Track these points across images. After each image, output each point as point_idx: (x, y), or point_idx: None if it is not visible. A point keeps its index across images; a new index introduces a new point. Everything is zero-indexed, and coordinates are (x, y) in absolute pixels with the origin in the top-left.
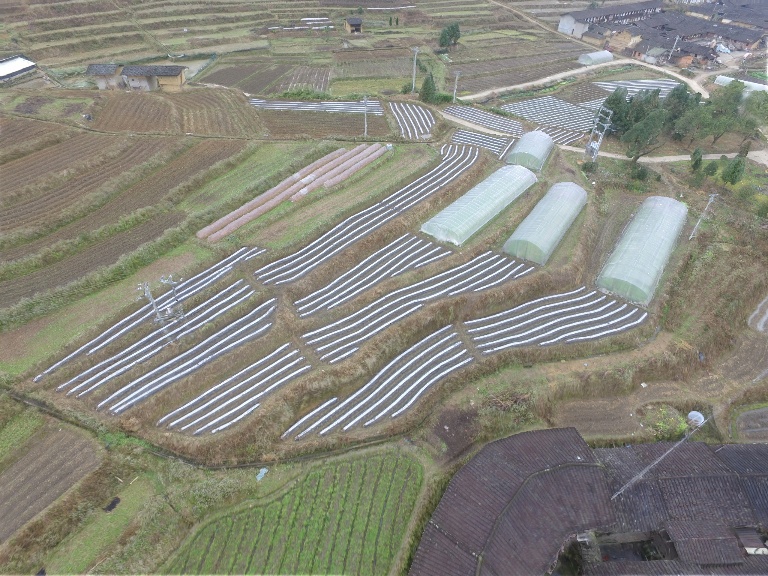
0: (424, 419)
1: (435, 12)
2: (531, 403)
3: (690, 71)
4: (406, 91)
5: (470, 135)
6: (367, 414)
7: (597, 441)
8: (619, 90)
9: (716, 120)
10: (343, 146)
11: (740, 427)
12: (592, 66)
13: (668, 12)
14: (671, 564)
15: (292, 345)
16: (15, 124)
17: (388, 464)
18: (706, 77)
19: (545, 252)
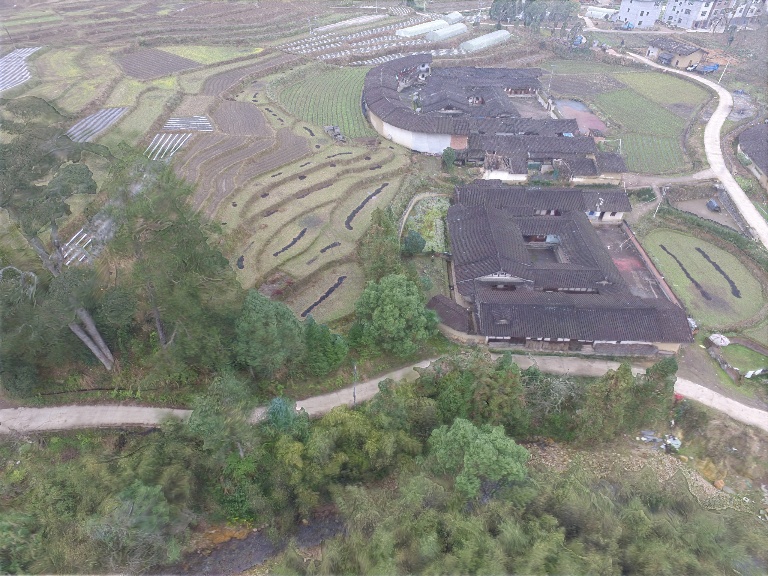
0: None
1: None
2: None
3: None
4: None
5: None
6: None
7: None
8: None
9: (540, 6)
10: None
11: None
12: None
13: None
14: None
15: None
16: (231, 5)
17: None
18: (583, 8)
19: (440, 36)
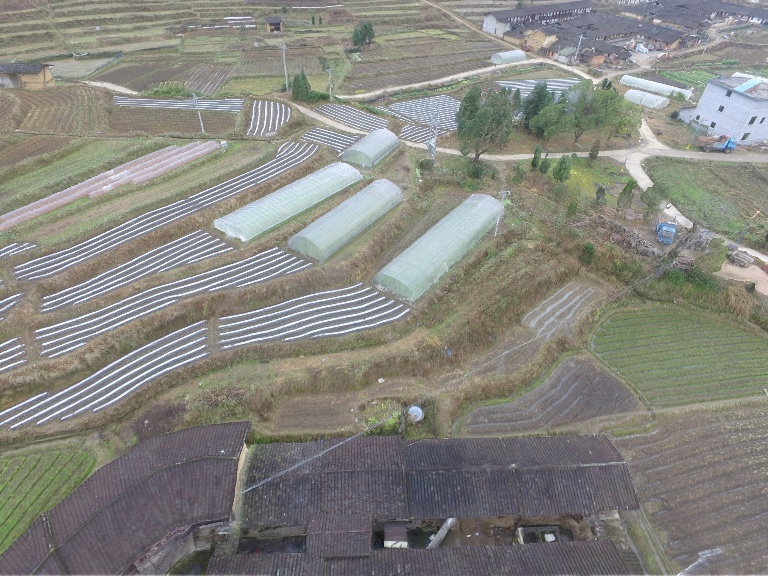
0: (126, 414)
1: (362, 11)
2: (243, 398)
3: (598, 70)
4: (285, 89)
5: (323, 133)
6: (69, 408)
7: (304, 436)
8: (474, 88)
9: (563, 118)
10: (177, 143)
11: (466, 422)
12: (501, 65)
13: (600, 12)
14: (295, 557)
15: (20, 340)
16: None
17: (63, 458)
18: (613, 76)
19: (322, 248)
